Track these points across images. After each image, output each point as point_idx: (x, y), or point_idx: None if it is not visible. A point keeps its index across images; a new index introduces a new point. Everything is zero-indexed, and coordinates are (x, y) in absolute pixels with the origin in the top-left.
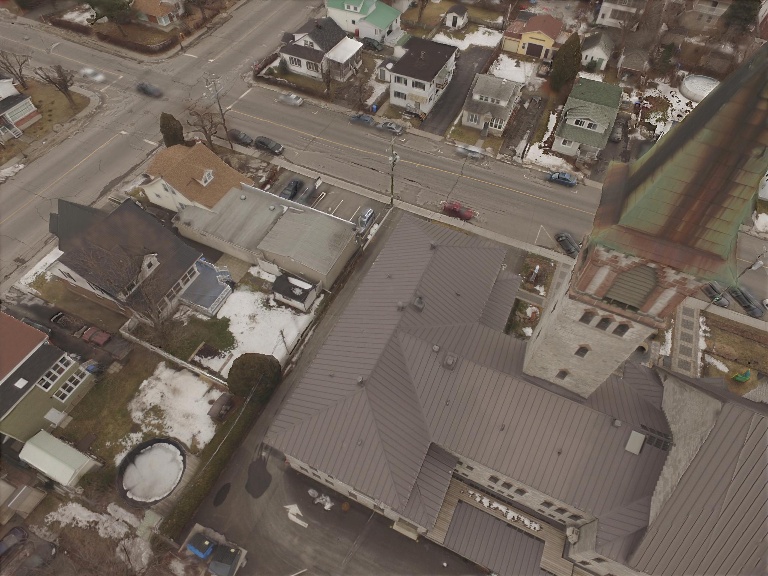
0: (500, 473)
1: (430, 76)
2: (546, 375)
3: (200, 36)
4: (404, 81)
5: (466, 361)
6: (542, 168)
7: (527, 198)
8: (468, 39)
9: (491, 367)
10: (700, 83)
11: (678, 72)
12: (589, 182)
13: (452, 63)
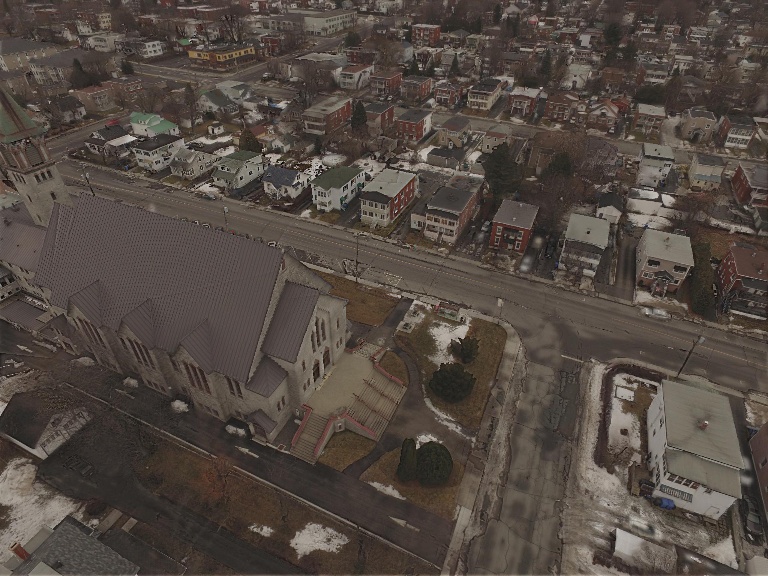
0: (21, 271)
1: (152, 149)
2: (38, 222)
3: (53, 138)
4: (140, 152)
5: (15, 222)
6: (203, 193)
7: (180, 204)
8: (217, 139)
9: (23, 223)
10: (334, 157)
11: (322, 152)
12: (225, 198)
13: (183, 146)
